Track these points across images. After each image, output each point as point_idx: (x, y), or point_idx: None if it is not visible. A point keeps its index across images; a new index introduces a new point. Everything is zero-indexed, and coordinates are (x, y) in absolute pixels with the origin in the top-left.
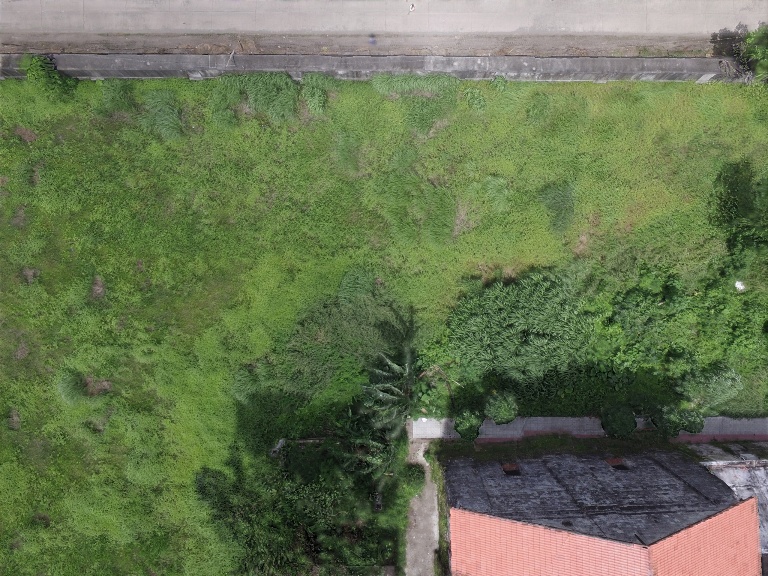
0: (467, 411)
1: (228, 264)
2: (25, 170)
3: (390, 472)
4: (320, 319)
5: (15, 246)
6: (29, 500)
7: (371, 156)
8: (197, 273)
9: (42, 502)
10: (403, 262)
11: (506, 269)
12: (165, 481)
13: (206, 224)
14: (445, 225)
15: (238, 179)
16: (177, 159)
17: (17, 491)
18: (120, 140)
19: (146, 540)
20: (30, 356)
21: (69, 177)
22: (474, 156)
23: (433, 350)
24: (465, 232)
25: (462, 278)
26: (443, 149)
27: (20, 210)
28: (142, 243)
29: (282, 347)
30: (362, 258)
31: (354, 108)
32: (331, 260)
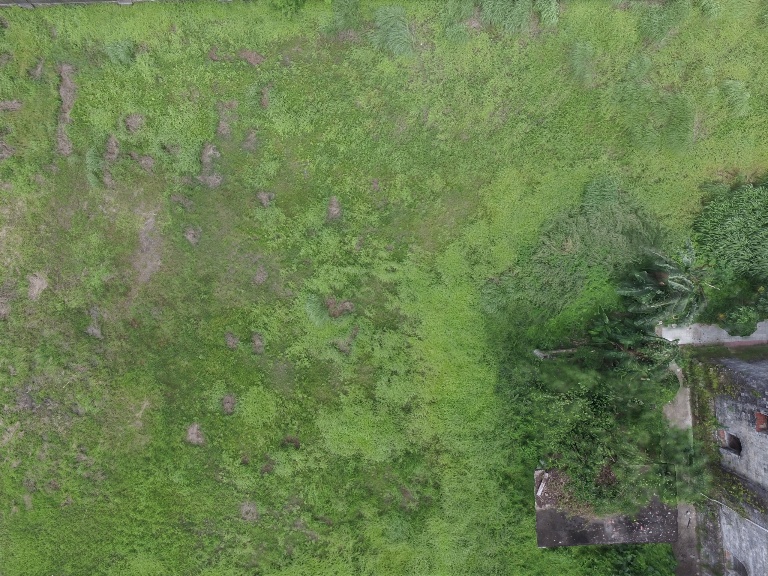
0: (743, 306)
1: (466, 179)
2: (256, 92)
3: (647, 377)
4: (567, 229)
5: (249, 169)
6: (276, 424)
7: (605, 66)
8: (435, 190)
9: (291, 425)
10: (642, 171)
11: (746, 174)
12: (416, 398)
13: (442, 140)
14: (689, 130)
15: (472, 94)
16: (409, 76)
17: (265, 415)
18: (349, 59)
19: (398, 458)
20: (269, 280)
21: (300, 98)
22: (710, 61)
23: (684, 255)
24: (703, 138)
25: (706, 183)
26: (676, 56)
27: (250, 134)
28: (378, 161)
29: (526, 260)
30: (602, 168)
31: (587, 18)
32: (570, 171)
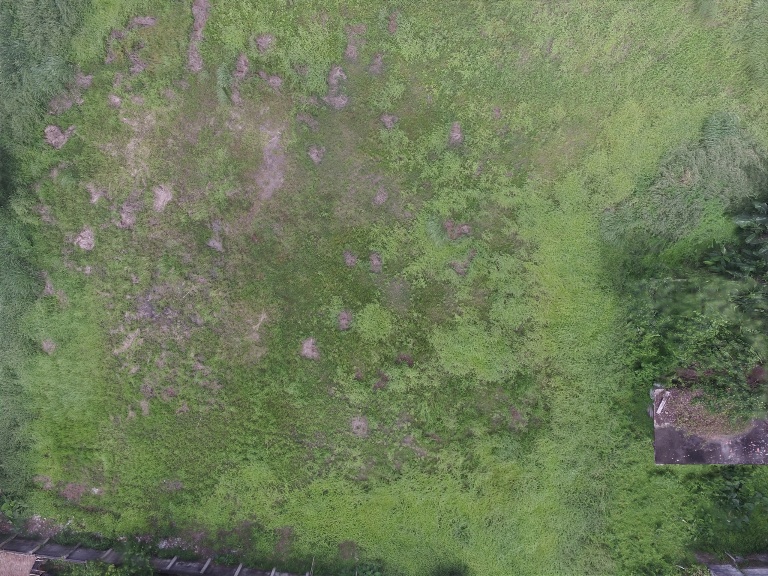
0: None
1: (586, 111)
2: (384, 17)
3: (761, 309)
4: (686, 161)
5: (375, 92)
6: (391, 341)
7: (727, 6)
8: (555, 120)
9: (406, 342)
10: (760, 109)
11: None
12: (530, 321)
13: (564, 72)
14: None
15: (596, 27)
16: (534, 8)
17: (381, 332)
18: None
19: (510, 379)
20: (388, 201)
21: (426, 25)
22: None
23: None
24: None
25: None
26: None
27: (376, 58)
28: (501, 90)
29: (642, 191)
30: (721, 105)
31: None
32: (689, 107)
